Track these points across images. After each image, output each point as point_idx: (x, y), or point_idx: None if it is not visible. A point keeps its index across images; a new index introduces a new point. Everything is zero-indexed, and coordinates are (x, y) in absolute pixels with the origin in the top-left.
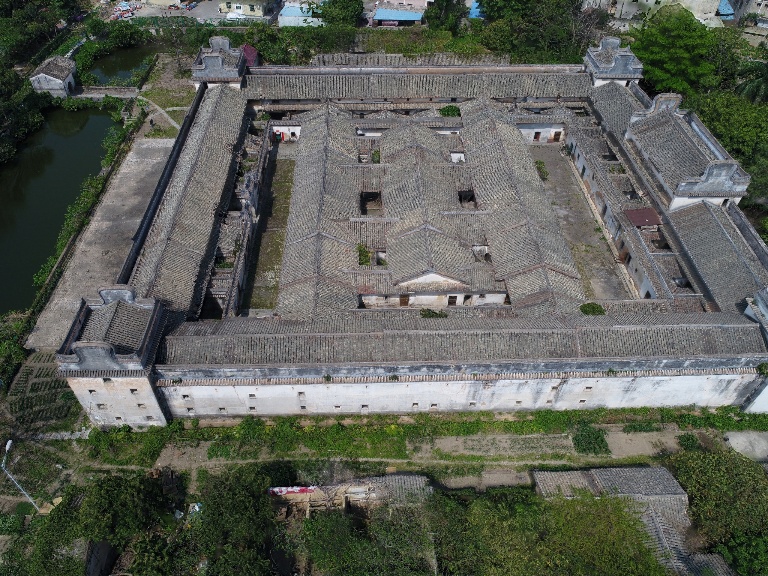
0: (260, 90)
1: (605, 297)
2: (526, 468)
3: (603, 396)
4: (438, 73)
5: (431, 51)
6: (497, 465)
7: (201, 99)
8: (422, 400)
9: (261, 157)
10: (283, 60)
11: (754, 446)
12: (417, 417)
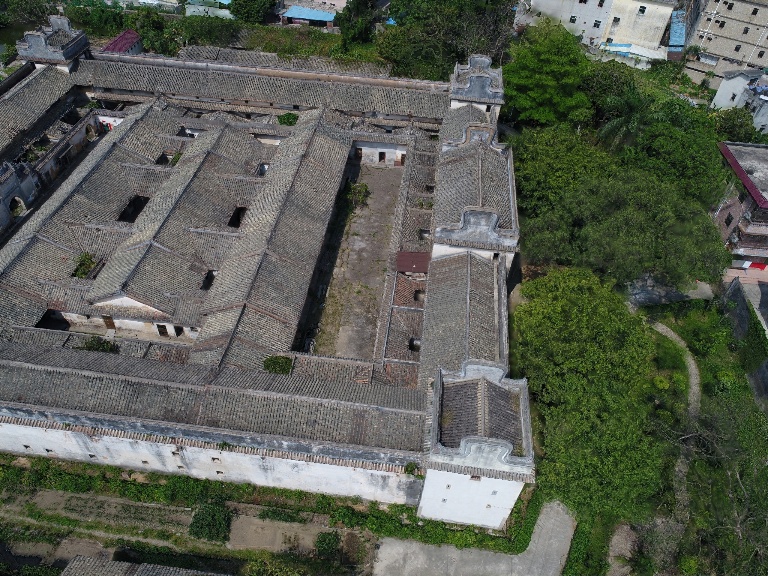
0: (90, 76)
1: (345, 349)
2: (118, 544)
3: (240, 470)
4: (290, 77)
5: (312, 54)
6: (87, 534)
7: (22, 79)
8: (31, 443)
9: (57, 146)
10: (162, 49)
11: (407, 561)
12: (35, 461)
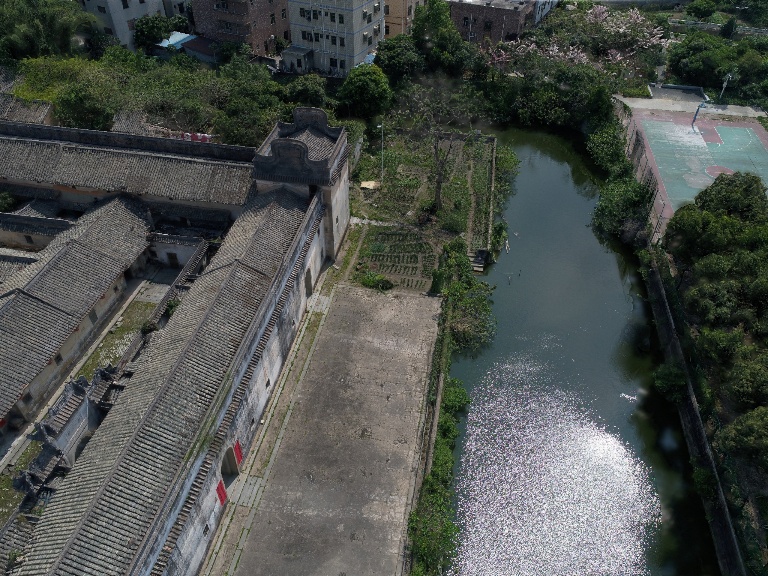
0: None
1: None
2: None
3: None
4: None
5: None
6: None
7: None
8: None
9: None
10: None
11: None
12: None
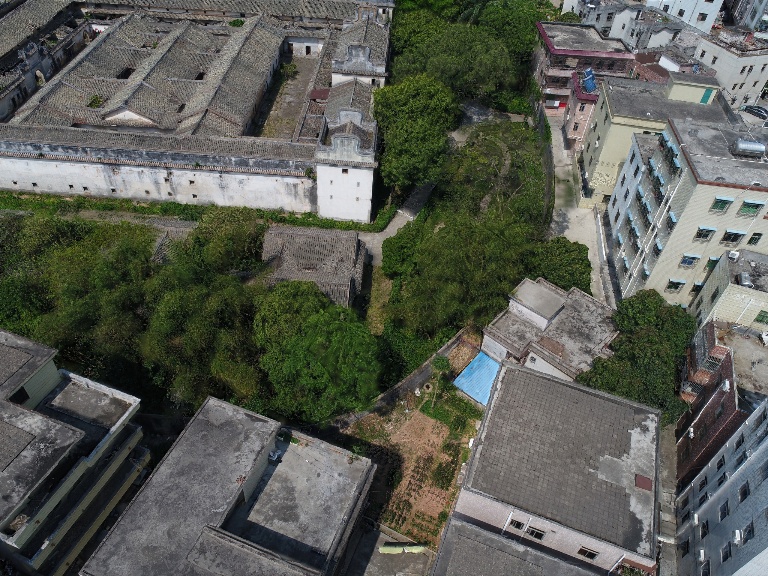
0: None
1: None
2: None
3: (208, 192)
4: None
5: None
6: None
7: None
8: (74, 182)
9: (64, 41)
10: None
11: None
12: (76, 198)
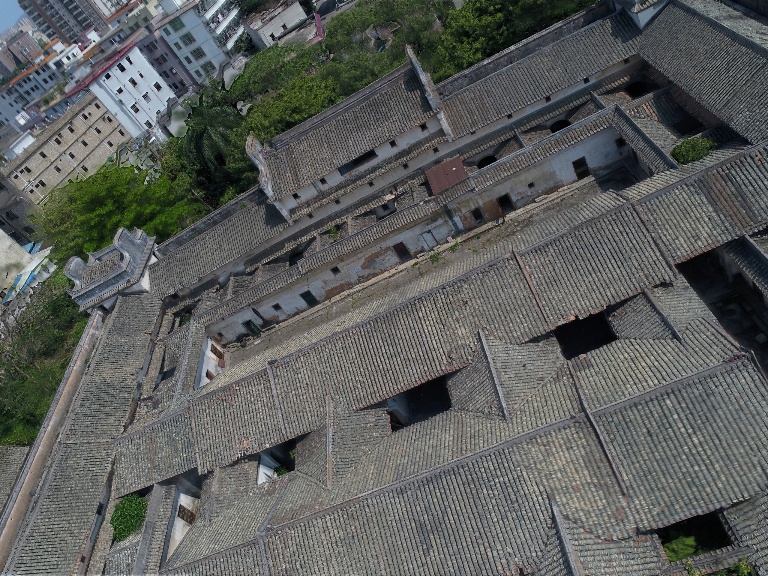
0: None
1: None
2: None
3: None
4: (7, 551)
5: None
6: None
7: None
8: None
9: None
10: None
11: None
12: None
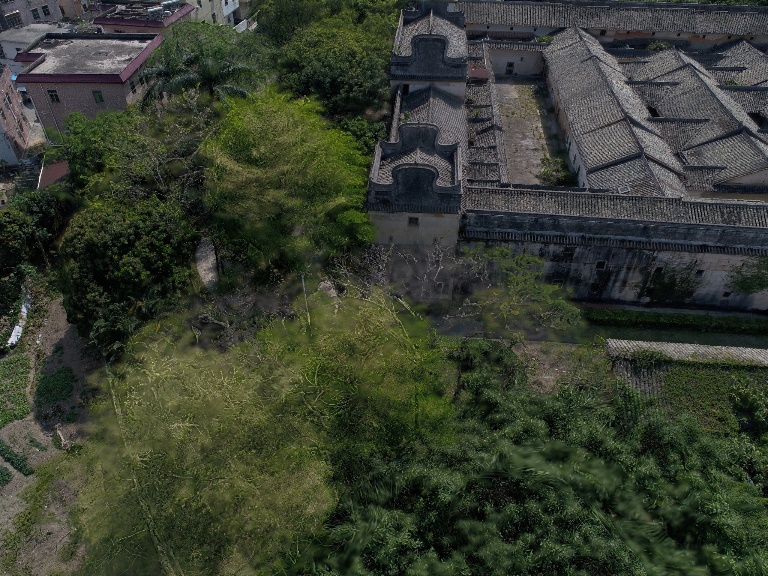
0: None
1: (510, 89)
2: None
3: None
4: None
5: None
6: None
7: None
8: None
9: None
10: None
11: None
12: None
